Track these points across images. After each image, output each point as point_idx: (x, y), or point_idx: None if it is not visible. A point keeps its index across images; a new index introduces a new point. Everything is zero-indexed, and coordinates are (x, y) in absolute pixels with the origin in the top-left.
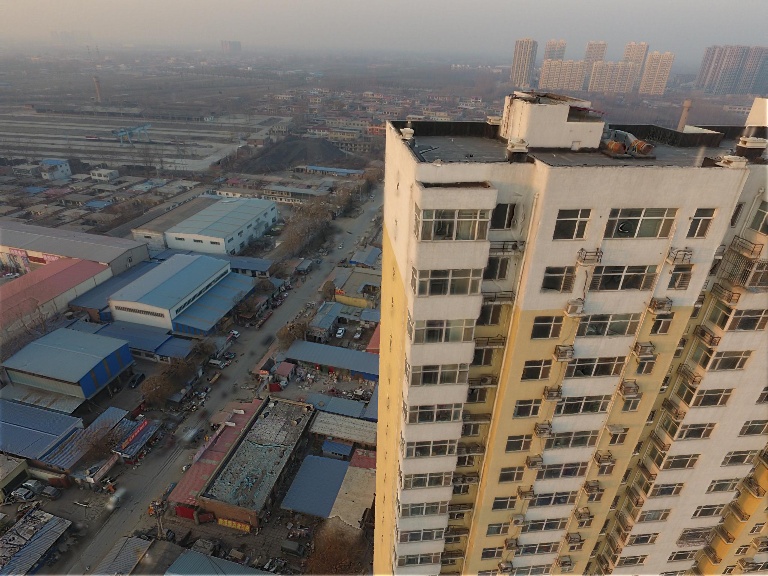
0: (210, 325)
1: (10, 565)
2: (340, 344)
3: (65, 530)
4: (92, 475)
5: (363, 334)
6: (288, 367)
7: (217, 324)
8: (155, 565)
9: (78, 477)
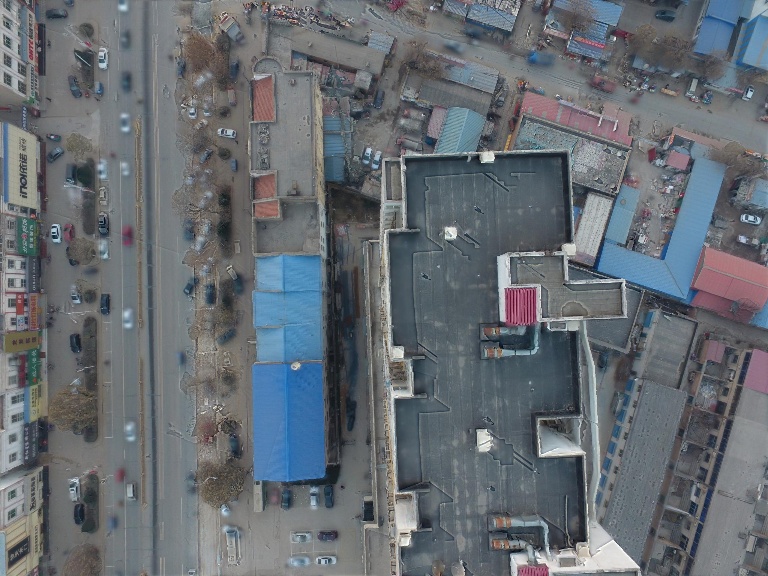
0: (754, 61)
1: (482, 8)
2: (721, 218)
3: (506, 30)
4: (550, 26)
5: (748, 247)
6: (680, 163)
7: (756, 69)
8: (475, 101)
9: (548, 17)
